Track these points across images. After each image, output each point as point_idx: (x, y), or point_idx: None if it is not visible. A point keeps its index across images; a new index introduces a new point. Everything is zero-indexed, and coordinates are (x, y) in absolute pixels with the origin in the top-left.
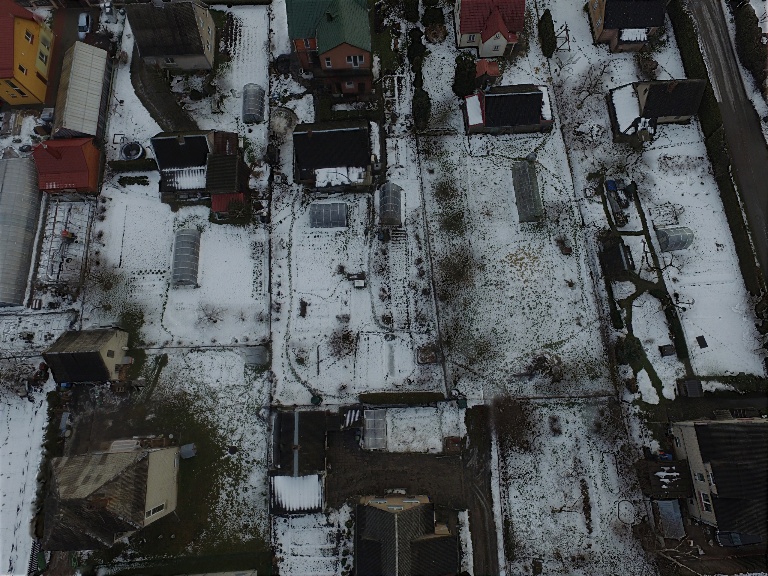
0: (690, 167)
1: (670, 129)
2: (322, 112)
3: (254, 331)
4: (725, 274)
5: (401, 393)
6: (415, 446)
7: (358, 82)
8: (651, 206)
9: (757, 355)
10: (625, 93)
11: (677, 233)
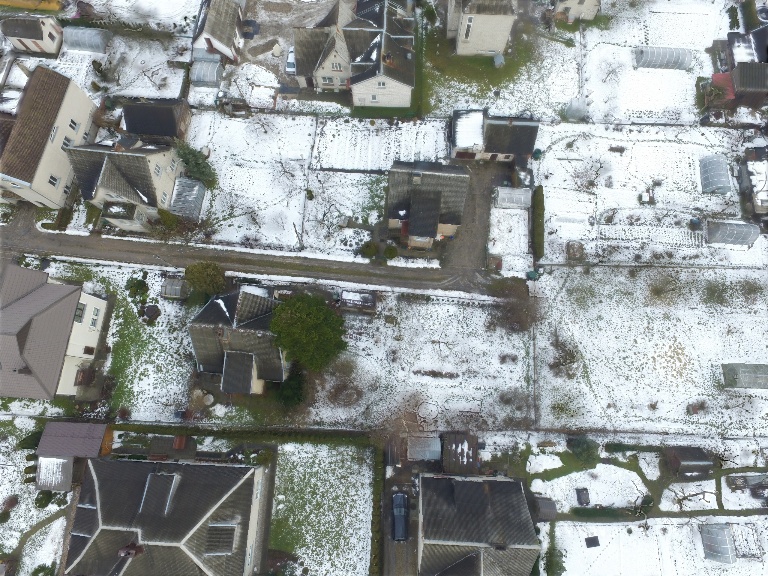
0: None
1: None
2: None
3: (596, 110)
4: None
5: None
6: (495, 231)
7: None
8: None
9: None
10: None
11: (730, 542)
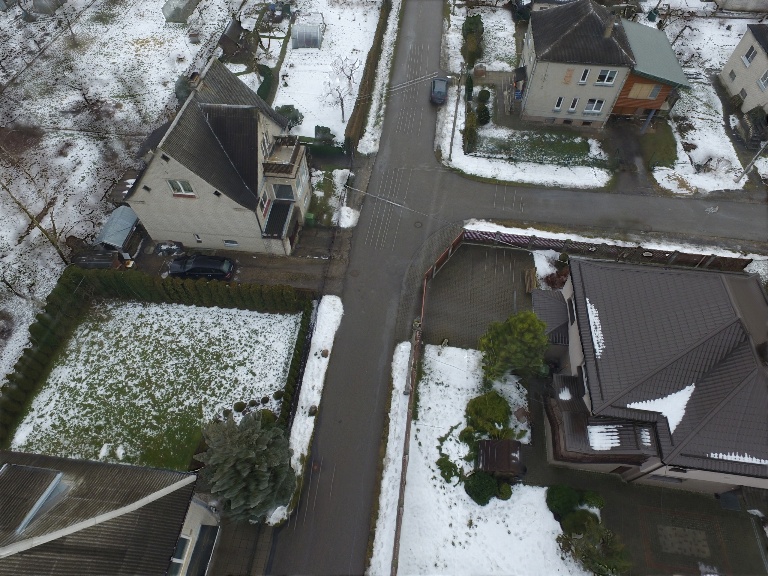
0: (359, 5)
1: None
2: None
3: None
4: None
5: None
6: None
7: None
8: None
9: (324, 103)
10: None
11: (302, 25)
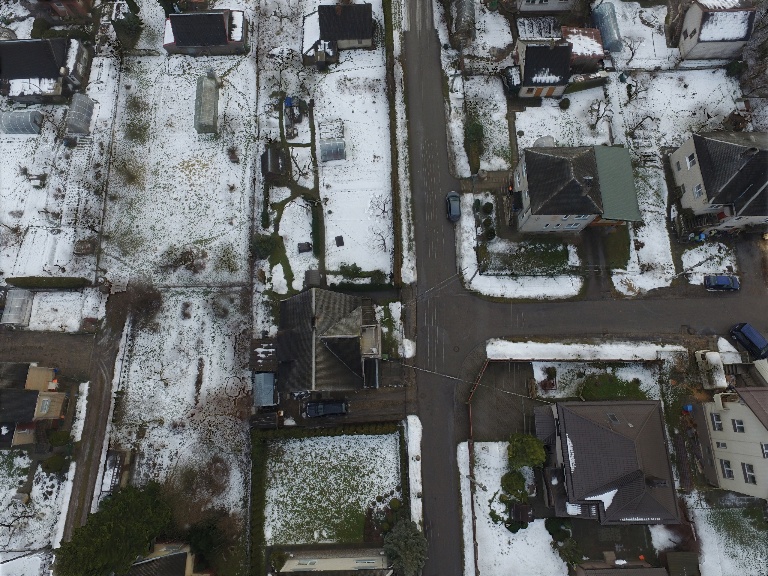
0: (366, 87)
1: (356, 54)
2: (32, 31)
3: None
4: (375, 182)
5: (45, 277)
6: (54, 325)
7: (66, 3)
8: (323, 121)
9: (373, 249)
10: (313, 19)
11: (328, 142)
